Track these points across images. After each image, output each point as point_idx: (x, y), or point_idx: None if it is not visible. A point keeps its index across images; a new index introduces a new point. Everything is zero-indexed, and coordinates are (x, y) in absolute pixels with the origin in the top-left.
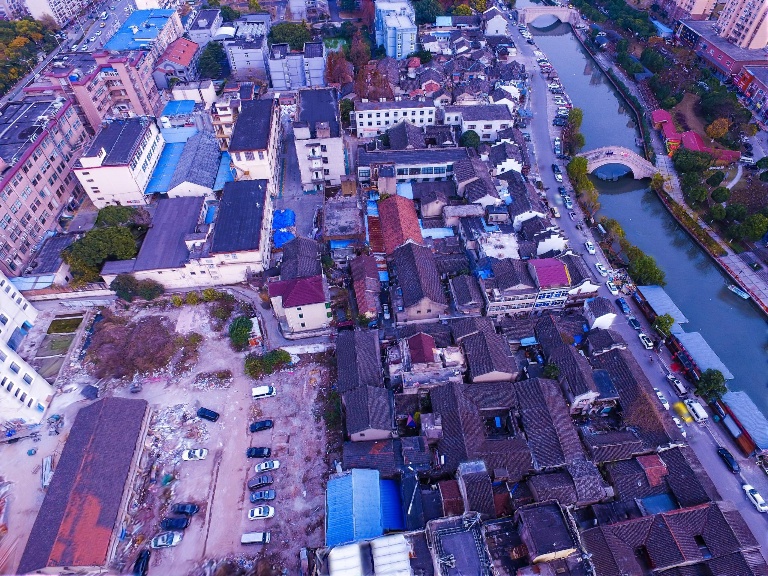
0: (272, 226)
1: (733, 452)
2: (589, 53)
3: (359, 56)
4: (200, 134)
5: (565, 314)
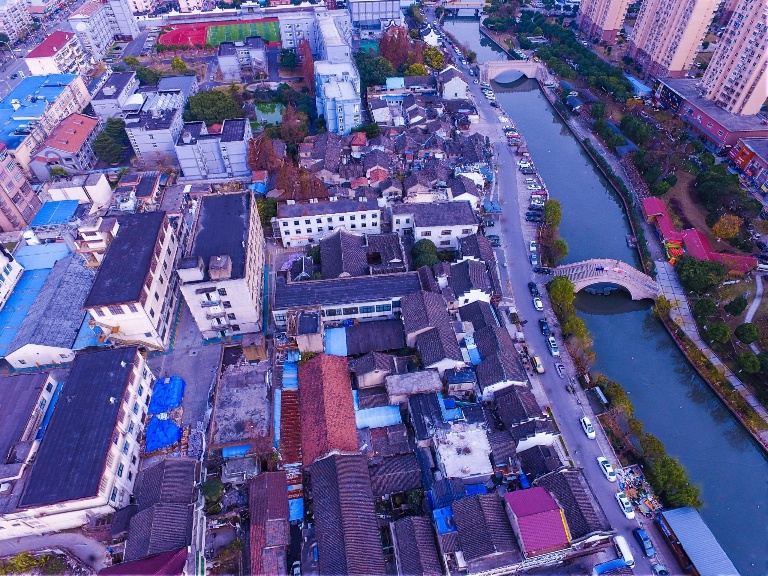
0: (148, 409)
1: None
2: (561, 117)
3: (292, 133)
4: (70, 258)
5: (563, 563)
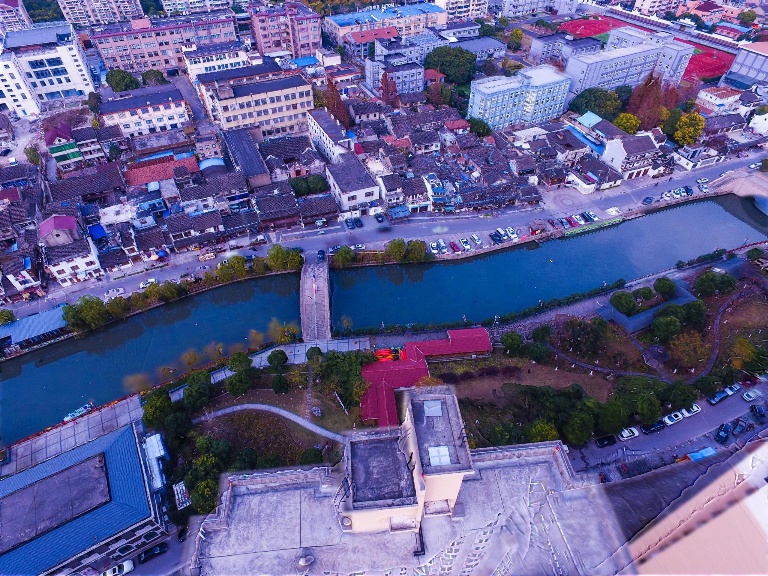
0: (170, 129)
1: None
2: None
3: None
4: None
5: None
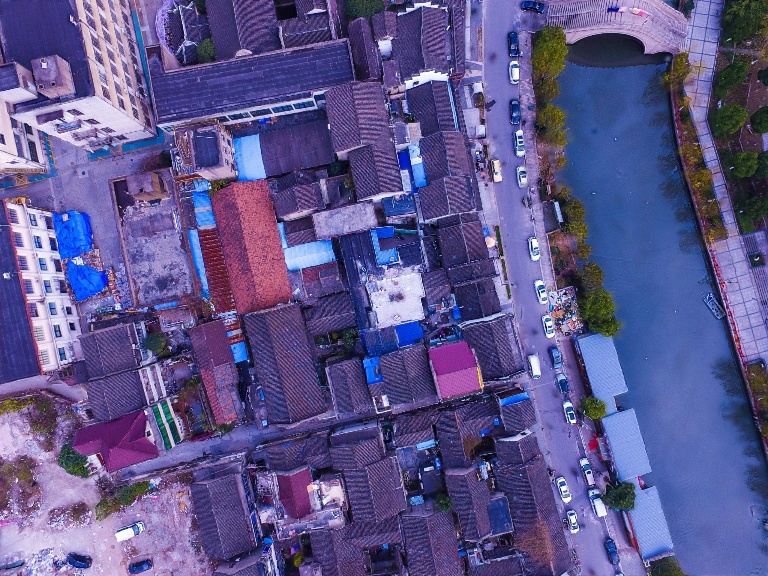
0: (59, 254)
1: (620, 541)
2: None
3: None
4: None
5: None
